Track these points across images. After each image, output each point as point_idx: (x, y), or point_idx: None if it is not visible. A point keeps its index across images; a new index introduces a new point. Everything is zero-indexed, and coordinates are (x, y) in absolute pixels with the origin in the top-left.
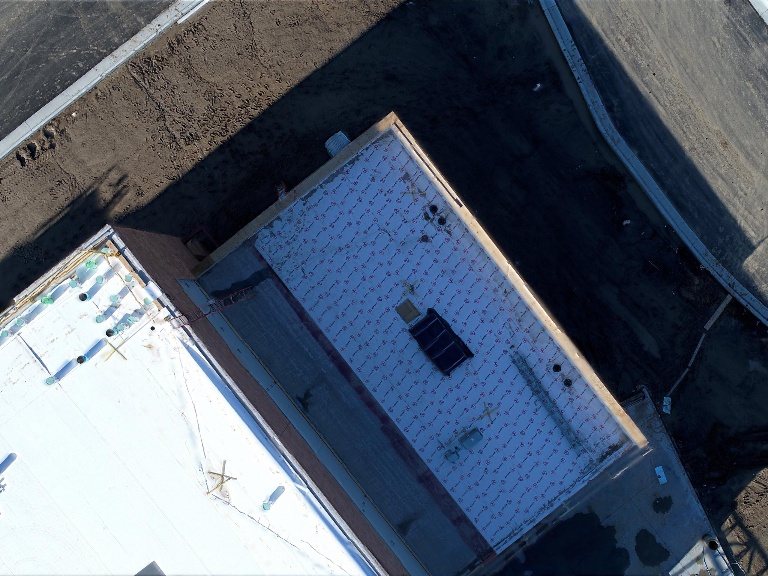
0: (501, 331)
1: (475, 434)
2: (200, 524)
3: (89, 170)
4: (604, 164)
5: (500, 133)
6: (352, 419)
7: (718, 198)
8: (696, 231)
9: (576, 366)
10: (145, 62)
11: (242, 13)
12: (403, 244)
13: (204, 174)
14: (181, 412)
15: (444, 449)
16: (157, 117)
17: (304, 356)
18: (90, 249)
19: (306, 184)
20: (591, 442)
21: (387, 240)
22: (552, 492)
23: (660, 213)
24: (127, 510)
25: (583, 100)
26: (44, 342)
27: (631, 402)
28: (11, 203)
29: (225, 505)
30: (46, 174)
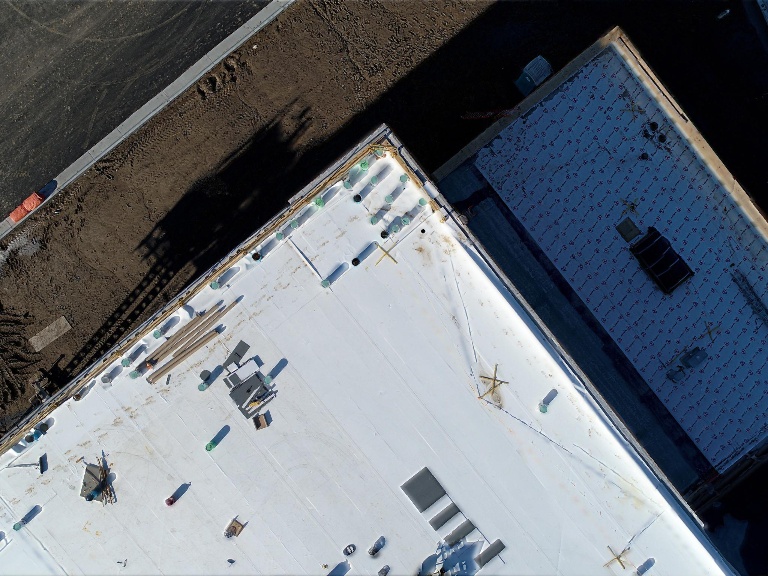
0: (721, 249)
1: (701, 352)
2: (472, 429)
3: (271, 103)
4: None
5: (685, 61)
6: (573, 339)
7: None
8: None
9: None
10: None
11: None
12: (623, 162)
13: (388, 105)
14: (452, 316)
15: (665, 369)
16: (340, 48)
17: (525, 276)
18: (367, 149)
19: (530, 100)
20: None
21: (607, 158)
22: None
23: None
24: (399, 415)
25: (766, 28)
26: (315, 246)
27: None
28: (193, 137)
29: (496, 410)
30: (227, 108)
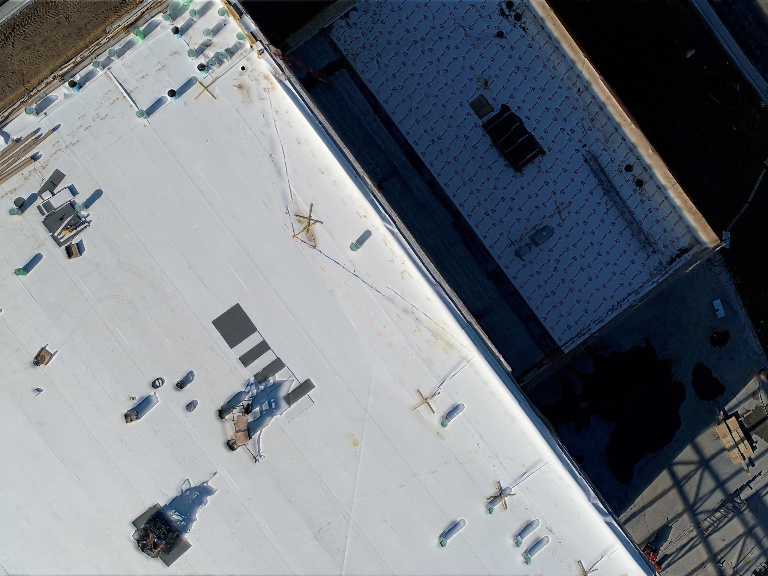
0: (574, 130)
1: (547, 228)
2: (285, 267)
3: None
4: None
5: None
6: (423, 213)
7: None
8: (758, 68)
9: (649, 163)
10: None
11: None
12: (478, 39)
13: None
14: (269, 154)
15: (514, 246)
16: None
17: (377, 148)
18: None
19: None
20: (661, 244)
21: (462, 35)
22: (621, 293)
23: (722, 49)
24: (212, 251)
25: None
26: (134, 78)
27: None
28: (74, 20)
29: (311, 249)
30: None
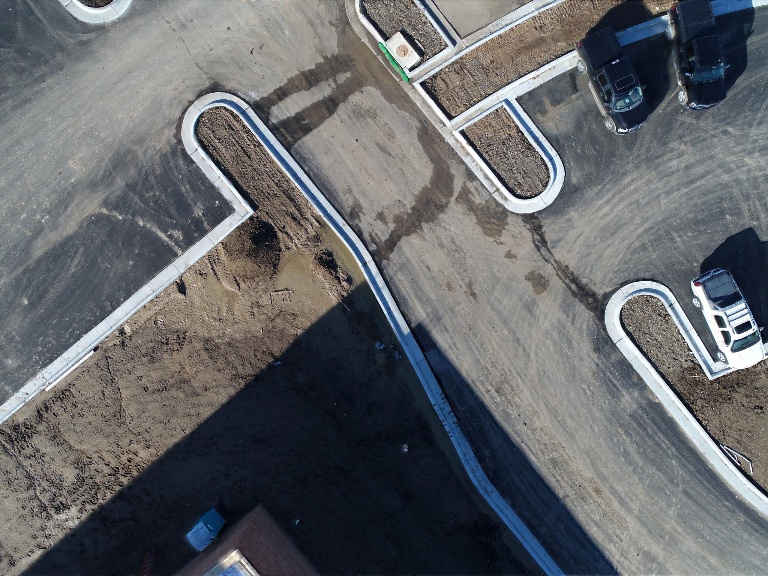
0: None
1: None
2: None
3: None
4: (478, 516)
5: (372, 490)
6: None
7: (594, 545)
8: None
9: None
10: (14, 429)
11: (110, 379)
12: None
13: (76, 542)
14: None
15: None
16: (27, 486)
17: None
18: None
19: None
20: None
21: None
22: None
23: (536, 561)
24: None
25: (455, 451)
26: None
27: None
28: None
29: None
30: None
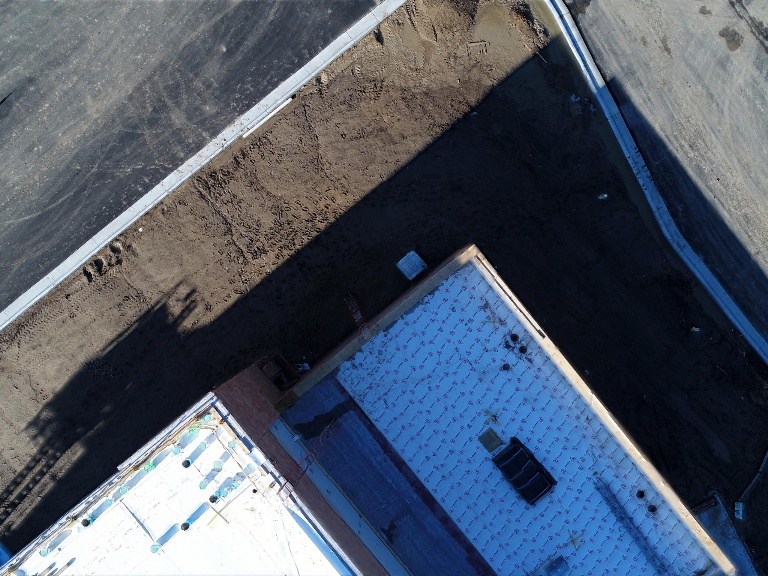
0: (584, 458)
1: (561, 564)
2: None
3: (156, 285)
4: (670, 270)
5: (566, 241)
6: (437, 549)
7: None
8: (763, 334)
9: (661, 494)
10: (211, 176)
11: (307, 126)
12: (485, 373)
13: (272, 288)
14: (284, 574)
15: None
16: (224, 231)
17: (388, 487)
18: (194, 417)
19: (389, 318)
20: (676, 567)
21: (469, 369)
22: None
23: (727, 317)
24: None
25: (648, 206)
26: (146, 507)
27: (703, 508)
28: (79, 319)
29: None
30: (113, 290)
